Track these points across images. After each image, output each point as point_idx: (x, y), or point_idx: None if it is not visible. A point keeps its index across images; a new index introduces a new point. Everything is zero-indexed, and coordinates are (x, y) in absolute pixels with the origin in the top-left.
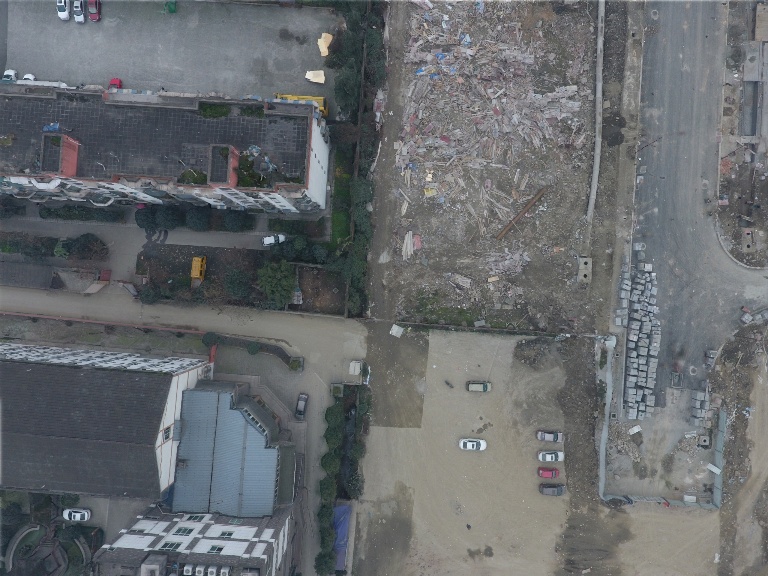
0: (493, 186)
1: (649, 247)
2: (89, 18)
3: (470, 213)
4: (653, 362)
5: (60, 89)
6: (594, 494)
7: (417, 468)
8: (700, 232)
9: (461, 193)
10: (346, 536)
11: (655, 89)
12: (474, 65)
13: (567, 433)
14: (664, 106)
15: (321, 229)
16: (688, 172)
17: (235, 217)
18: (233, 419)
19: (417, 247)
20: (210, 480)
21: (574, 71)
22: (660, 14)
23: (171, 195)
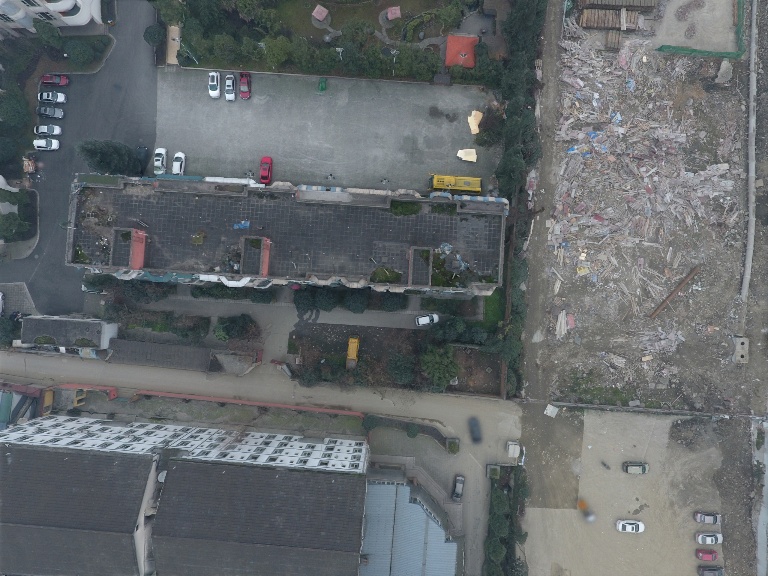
0: (646, 264)
1: None
2: (239, 96)
3: (623, 292)
4: None
5: (254, 188)
6: None
7: (573, 550)
8: None
9: (614, 271)
10: None
11: None
12: (626, 143)
13: (724, 514)
14: None
15: (474, 308)
16: None
17: (397, 301)
18: (413, 513)
19: (571, 326)
20: (389, 574)
21: (725, 149)
22: None
23: None
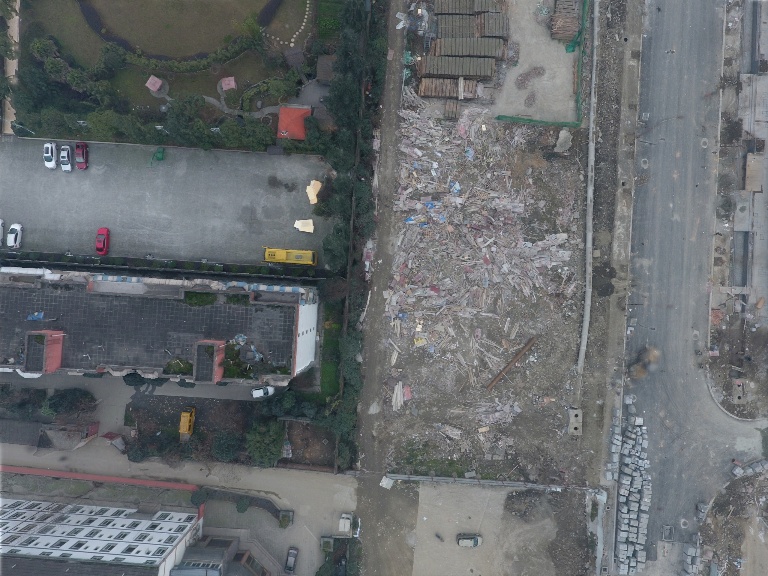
0: (483, 335)
1: (640, 399)
2: (76, 166)
3: (460, 363)
4: (644, 518)
5: (44, 281)
6: None
7: None
8: (691, 383)
9: (451, 342)
10: None
11: (645, 239)
12: (464, 213)
13: None
14: (654, 256)
15: (310, 380)
16: (679, 323)
17: None
18: None
19: (407, 398)
20: None
21: (564, 219)
22: (650, 163)
23: None
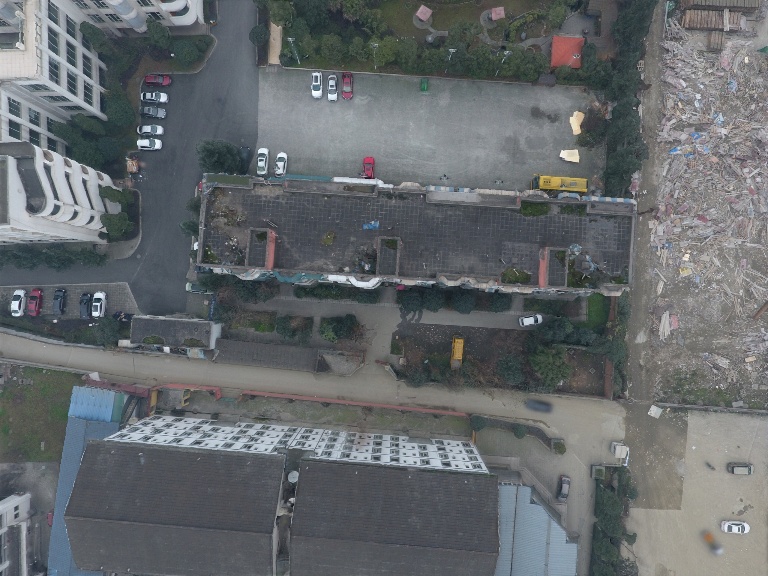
0: (748, 265)
1: None
2: (341, 96)
3: (726, 293)
4: None
5: (385, 189)
6: None
7: (677, 551)
8: None
9: (716, 272)
10: None
11: None
12: (728, 144)
13: None
14: None
15: (577, 309)
16: None
17: (506, 301)
18: (534, 514)
19: (674, 327)
20: (509, 575)
21: None
22: None
23: None
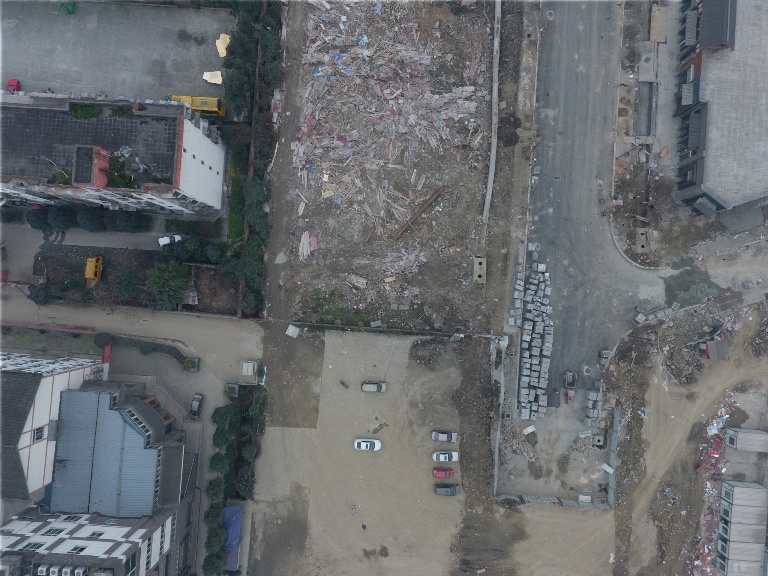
0: (390, 186)
1: (544, 247)
2: None
3: (367, 213)
4: (545, 362)
5: None
6: (489, 494)
7: (313, 468)
8: (595, 232)
9: (358, 193)
10: (238, 536)
11: (550, 90)
12: (371, 66)
13: (463, 433)
14: (559, 107)
15: (218, 230)
16: (583, 172)
17: (126, 218)
18: (112, 419)
19: (314, 247)
20: (90, 480)
21: (471, 72)
22: (556, 15)
23: (55, 196)
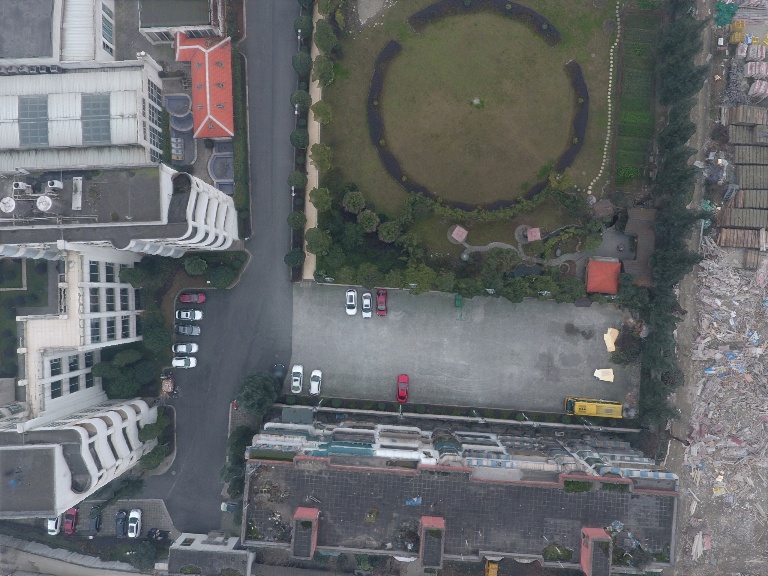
0: None
1: None
2: (375, 312)
3: (759, 513)
4: None
5: (428, 469)
6: None
7: None
8: None
9: (750, 492)
10: None
11: None
12: (763, 364)
13: None
14: None
15: None
16: None
17: None
18: None
19: (707, 548)
20: None
21: None
22: None
23: None
